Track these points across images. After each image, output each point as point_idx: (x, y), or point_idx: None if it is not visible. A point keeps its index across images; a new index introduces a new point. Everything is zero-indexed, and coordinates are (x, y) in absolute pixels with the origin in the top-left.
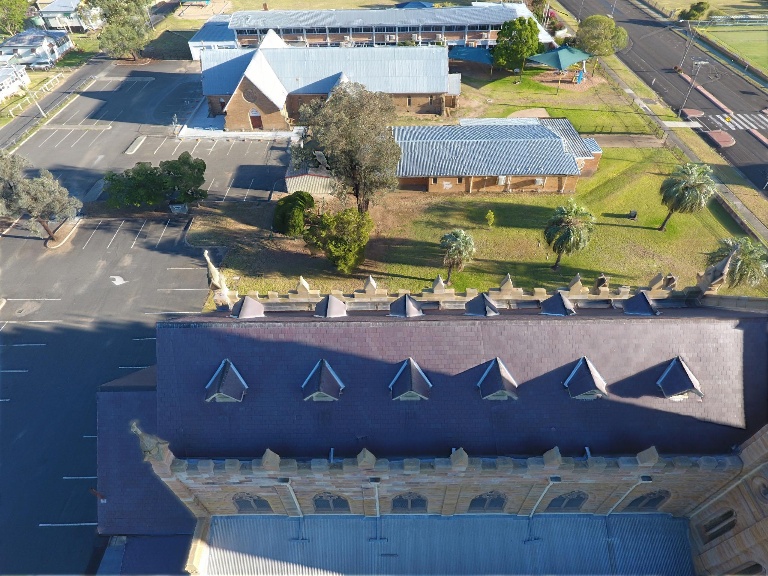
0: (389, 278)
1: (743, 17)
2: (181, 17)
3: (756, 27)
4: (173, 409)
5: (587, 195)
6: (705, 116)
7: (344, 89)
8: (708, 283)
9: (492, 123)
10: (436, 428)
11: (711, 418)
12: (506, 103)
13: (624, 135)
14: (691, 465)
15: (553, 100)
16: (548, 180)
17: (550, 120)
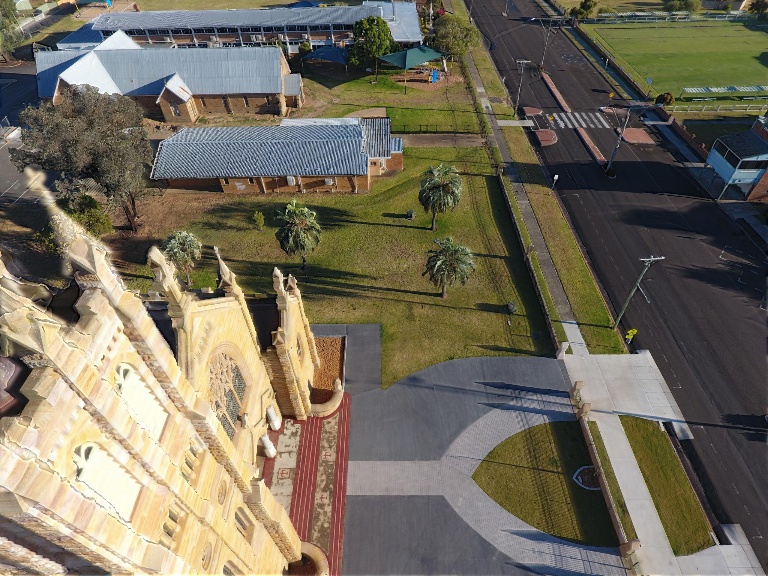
0: (133, 279)
1: (630, 14)
2: (77, 18)
3: (644, 24)
4: None
5: (379, 195)
6: (542, 115)
7: (74, 91)
8: None
9: (312, 123)
10: None
11: None
12: (350, 103)
13: (450, 134)
14: None
15: (399, 99)
16: (339, 180)
17: (371, 120)
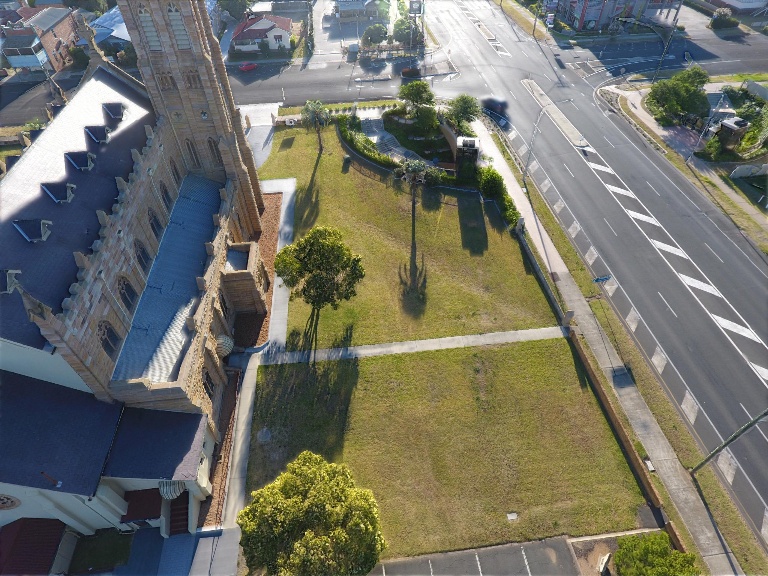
0: None
1: None
2: None
3: None
4: (0, 323)
5: None
6: None
7: None
8: (60, 99)
9: None
10: (98, 199)
11: (139, 116)
12: None
13: None
14: (159, 128)
15: None
16: None
17: None
